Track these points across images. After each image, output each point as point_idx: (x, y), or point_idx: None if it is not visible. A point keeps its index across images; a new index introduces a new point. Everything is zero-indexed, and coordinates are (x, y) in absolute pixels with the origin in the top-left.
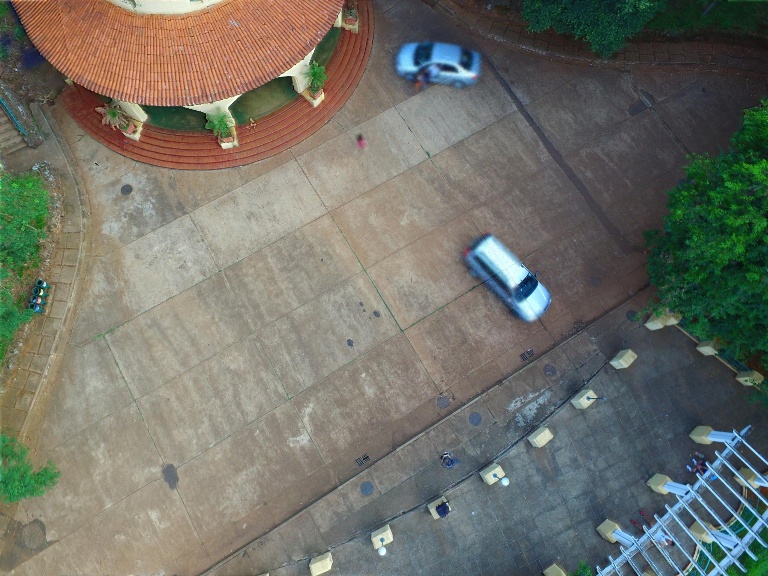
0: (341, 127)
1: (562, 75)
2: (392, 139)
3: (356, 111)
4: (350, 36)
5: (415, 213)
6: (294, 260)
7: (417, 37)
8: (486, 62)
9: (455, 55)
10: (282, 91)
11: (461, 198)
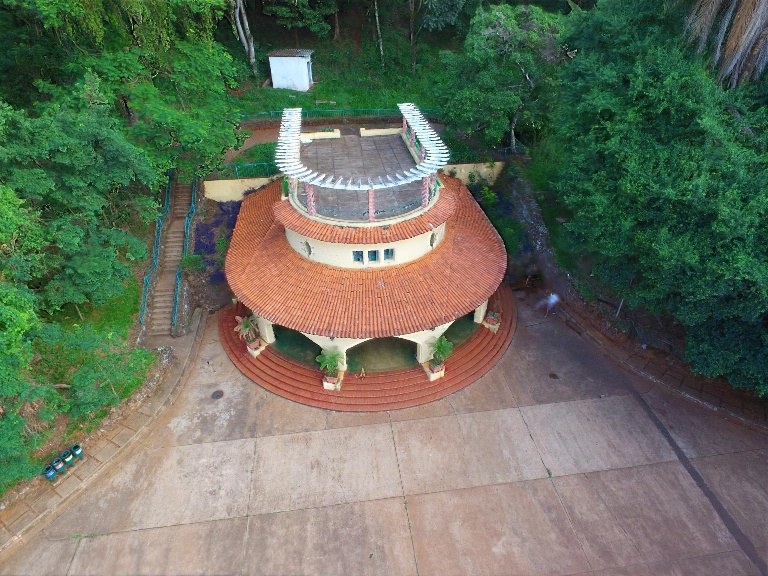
0: (452, 409)
1: (743, 439)
2: (507, 440)
3: (473, 399)
4: (488, 333)
5: (516, 542)
6: (337, 540)
7: (558, 353)
8: (637, 397)
9: (599, 380)
10: (404, 357)
11: (587, 547)
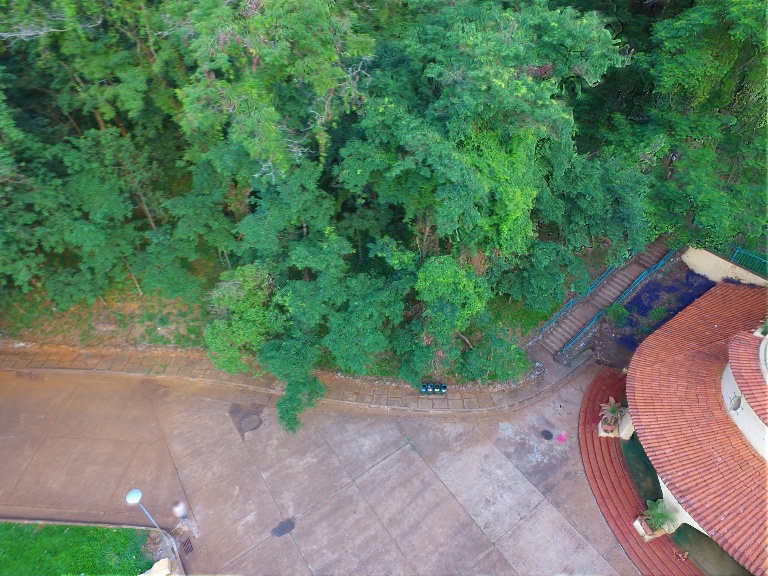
0: None
1: None
2: None
3: None
4: None
5: None
6: None
7: None
8: None
9: None
10: None
11: None
